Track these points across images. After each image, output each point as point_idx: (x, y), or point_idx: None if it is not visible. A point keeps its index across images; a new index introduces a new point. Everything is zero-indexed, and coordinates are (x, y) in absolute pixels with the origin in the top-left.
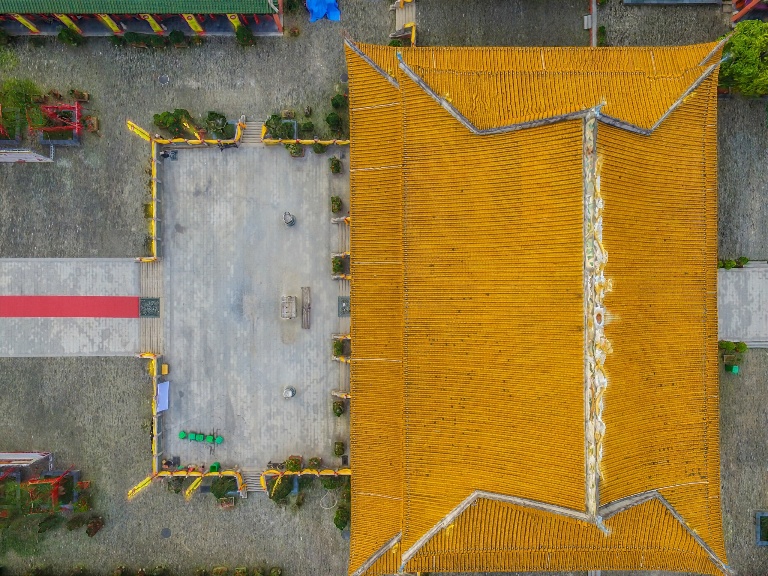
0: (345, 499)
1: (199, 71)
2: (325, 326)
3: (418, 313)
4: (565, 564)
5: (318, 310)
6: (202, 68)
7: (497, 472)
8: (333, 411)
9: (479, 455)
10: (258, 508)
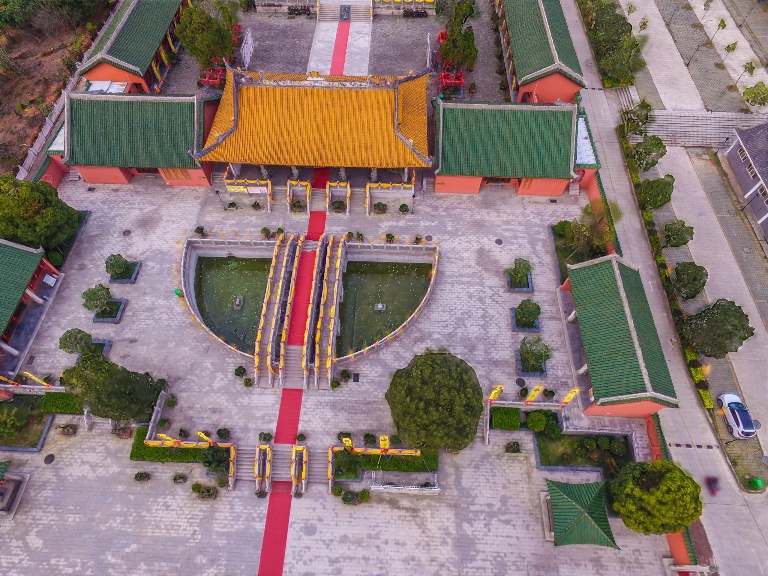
0: None
1: (220, 1)
2: None
3: None
4: None
5: None
6: (218, 0)
7: None
8: None
9: None
10: None
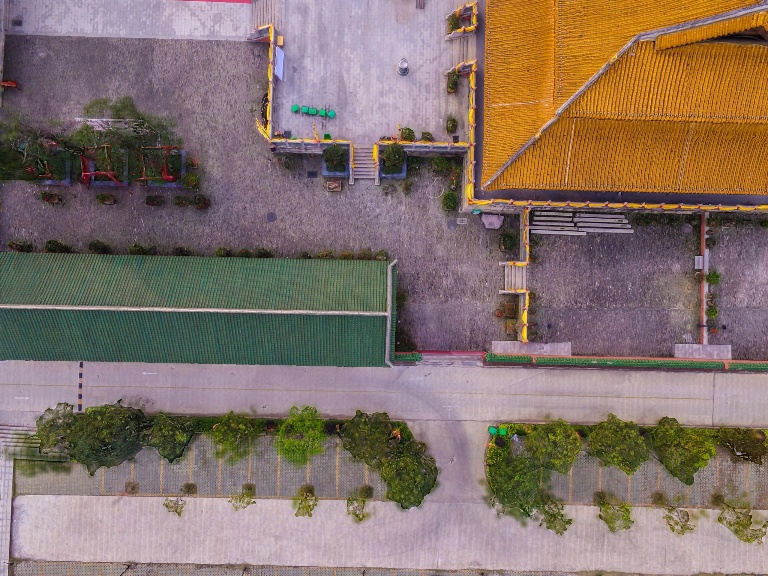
0: (454, 181)
1: None
2: (439, 7)
3: None
4: (697, 184)
5: None
6: None
7: (659, 11)
8: (446, 90)
9: (638, 2)
10: (364, 195)
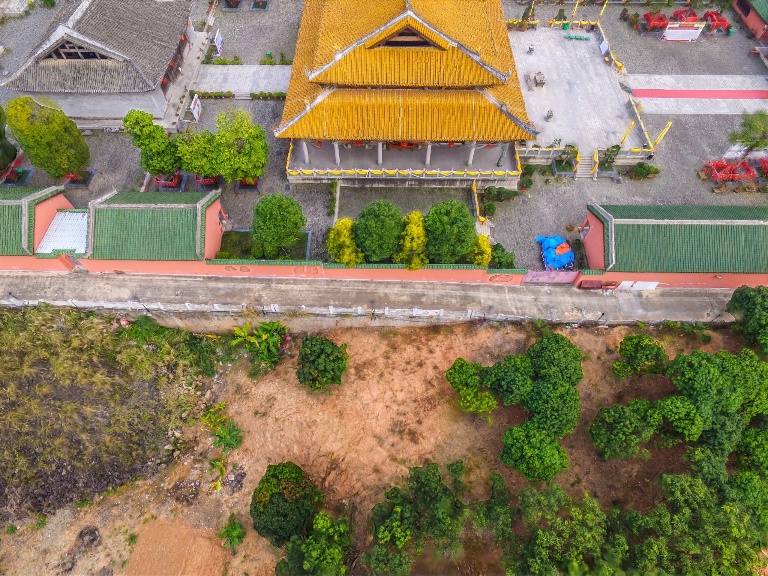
0: None
1: None
2: None
3: (479, 3)
4: None
5: (521, 82)
6: None
7: None
8: None
9: None
10: None
